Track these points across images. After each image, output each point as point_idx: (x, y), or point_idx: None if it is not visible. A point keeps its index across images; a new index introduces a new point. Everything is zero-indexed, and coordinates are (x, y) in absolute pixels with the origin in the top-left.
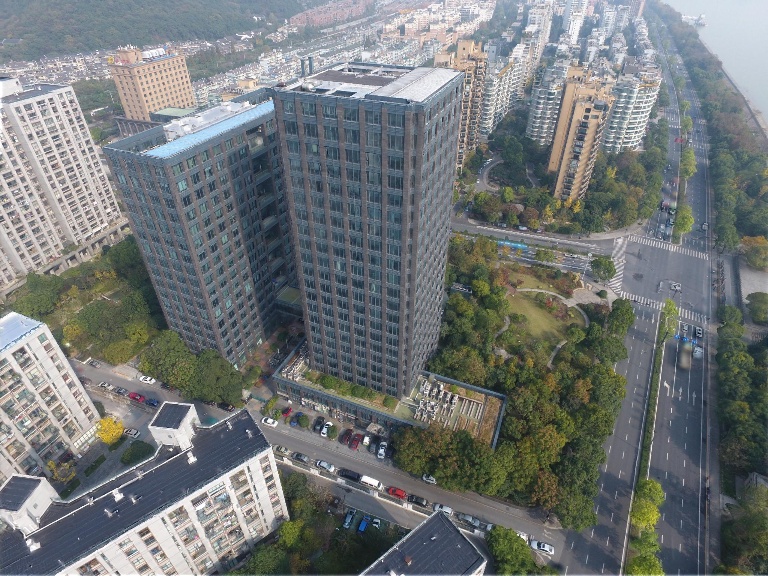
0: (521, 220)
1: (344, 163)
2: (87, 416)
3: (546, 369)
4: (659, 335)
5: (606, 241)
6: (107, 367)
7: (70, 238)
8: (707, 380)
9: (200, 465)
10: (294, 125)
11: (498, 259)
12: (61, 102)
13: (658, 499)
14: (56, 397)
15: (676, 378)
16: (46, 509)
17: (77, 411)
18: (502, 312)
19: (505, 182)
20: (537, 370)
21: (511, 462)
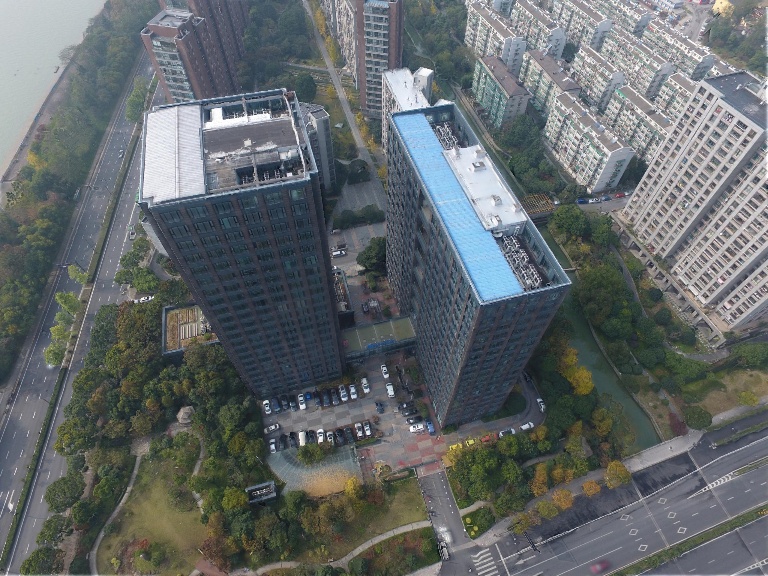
0: None
1: None
2: None
3: None
4: None
5: None
6: None
7: None
8: None
9: None
10: None
11: None
12: None
13: (49, 347)
14: None
15: None
16: (314, 127)
17: None
18: None
19: None
20: None
21: None
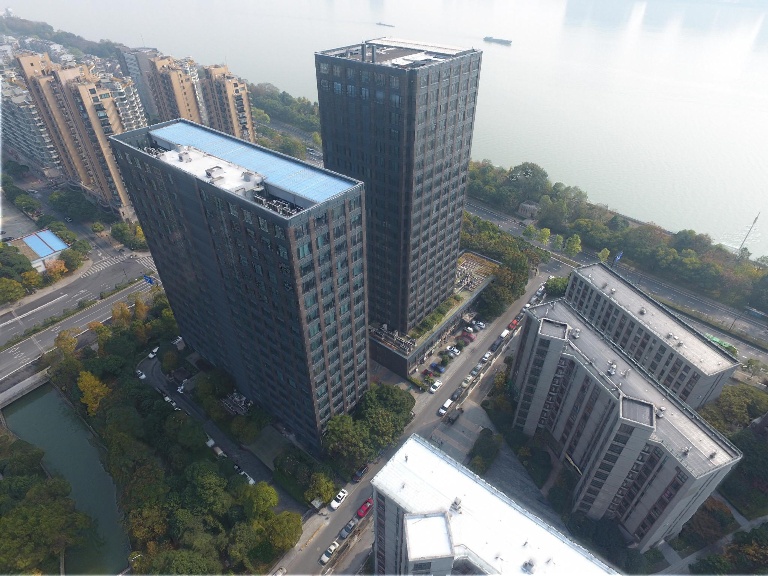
0: None
1: None
2: None
3: None
4: None
5: None
6: (289, 559)
7: None
8: None
9: (579, 333)
10: (424, 97)
11: None
12: None
13: None
14: None
15: None
16: None
17: None
18: None
19: None
20: None
21: None
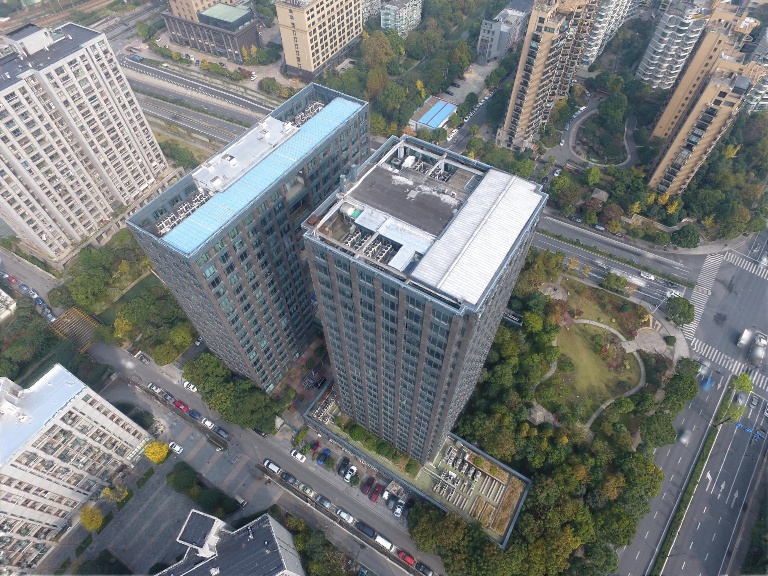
0: (600, 218)
1: (380, 318)
2: (136, 436)
3: (581, 442)
4: (720, 408)
5: (696, 258)
6: (155, 364)
7: (118, 199)
8: (757, 477)
9: None
10: (326, 269)
11: (562, 271)
12: (94, 55)
13: None
14: (106, 434)
15: (722, 469)
16: None
17: (126, 437)
18: (550, 358)
19: (594, 148)
20: (571, 442)
21: (519, 566)
